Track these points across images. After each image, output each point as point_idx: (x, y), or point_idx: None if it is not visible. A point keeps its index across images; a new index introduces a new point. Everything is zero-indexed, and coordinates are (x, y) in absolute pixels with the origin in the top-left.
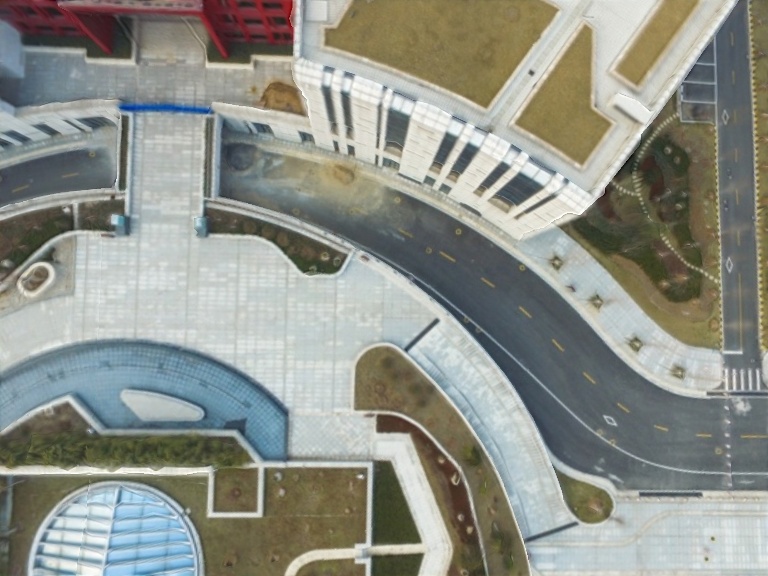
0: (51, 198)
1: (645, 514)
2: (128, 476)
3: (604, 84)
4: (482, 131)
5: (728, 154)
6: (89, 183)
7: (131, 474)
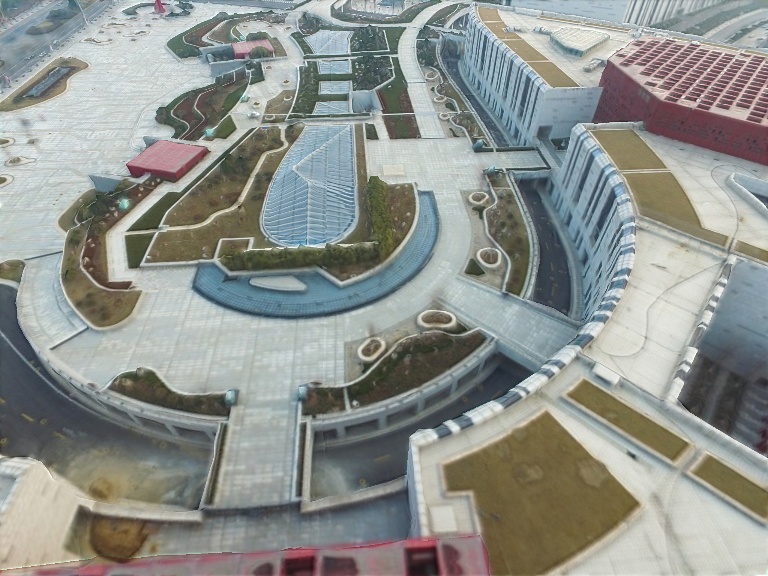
0: (368, 410)
1: None
2: None
3: None
4: None
5: None
6: (363, 452)
7: None
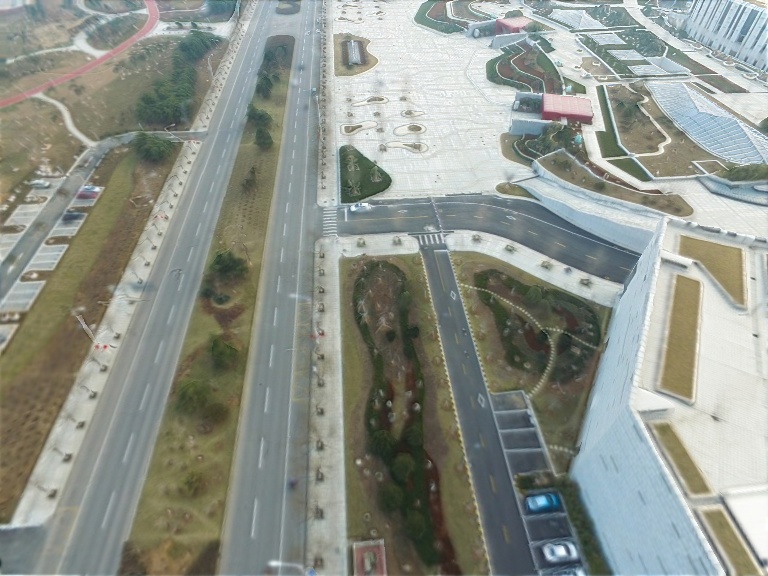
0: None
1: None
2: None
3: (699, 276)
4: (760, 240)
5: (472, 369)
6: None
7: None
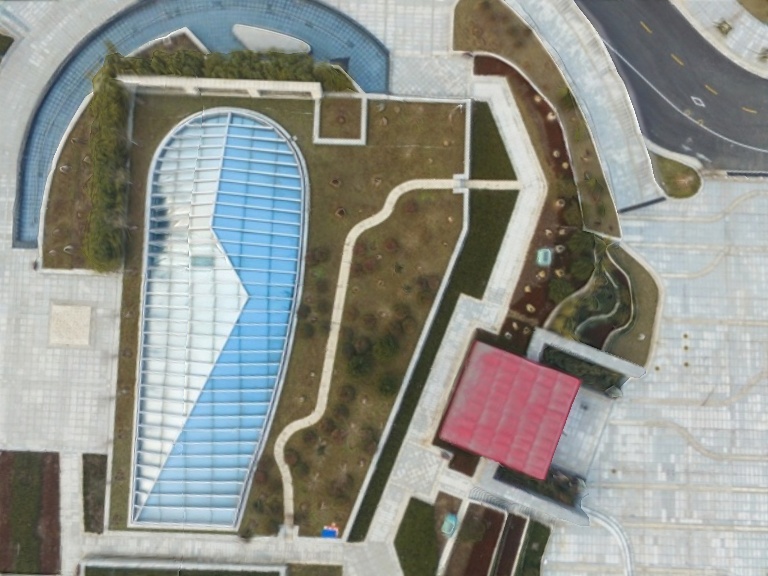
0: None
1: (733, 192)
2: (239, 102)
3: None
4: None
5: None
6: None
7: (242, 100)
